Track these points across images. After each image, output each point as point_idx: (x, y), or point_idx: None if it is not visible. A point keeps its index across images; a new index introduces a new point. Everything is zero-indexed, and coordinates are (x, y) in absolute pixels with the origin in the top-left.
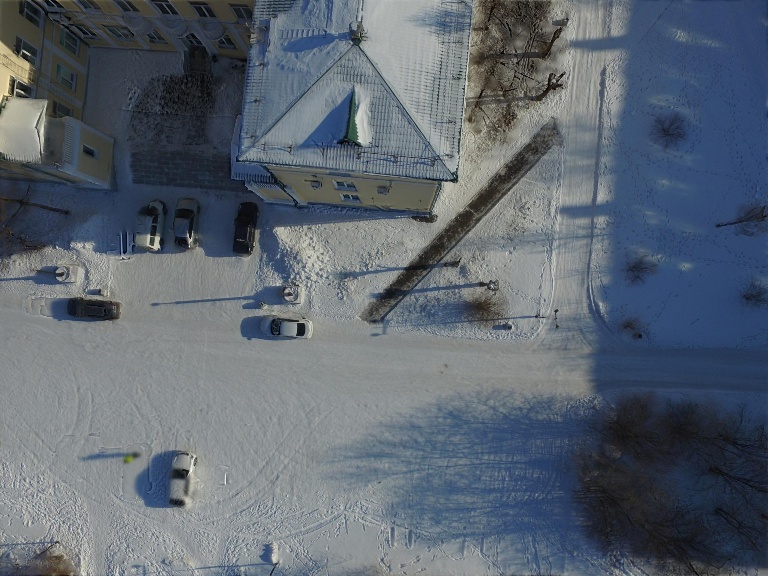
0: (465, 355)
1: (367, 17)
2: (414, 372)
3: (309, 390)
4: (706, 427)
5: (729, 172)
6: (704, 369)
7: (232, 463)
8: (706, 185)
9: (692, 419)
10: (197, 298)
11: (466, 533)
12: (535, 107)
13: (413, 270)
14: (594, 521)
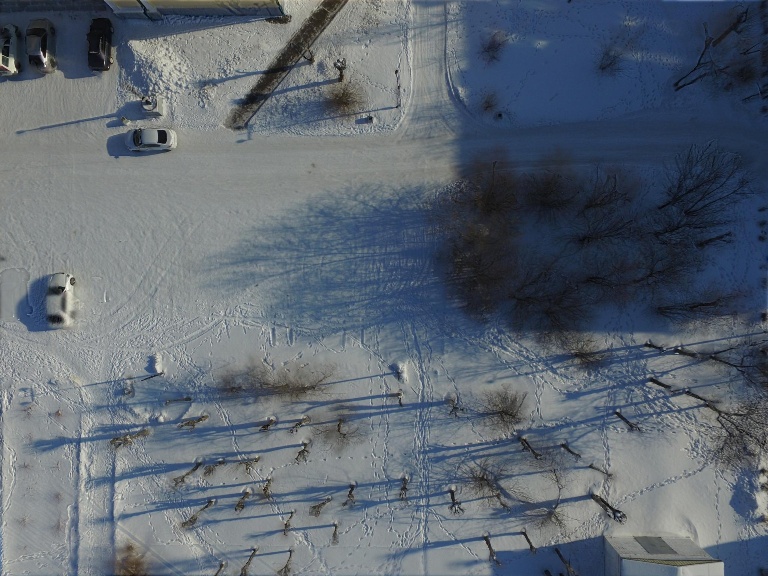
0: (331, 153)
1: None
2: (282, 174)
3: (180, 202)
4: (566, 191)
5: None
6: (568, 145)
7: (110, 281)
8: None
9: None
10: (61, 121)
11: (346, 326)
12: None
13: (272, 73)
14: (469, 301)
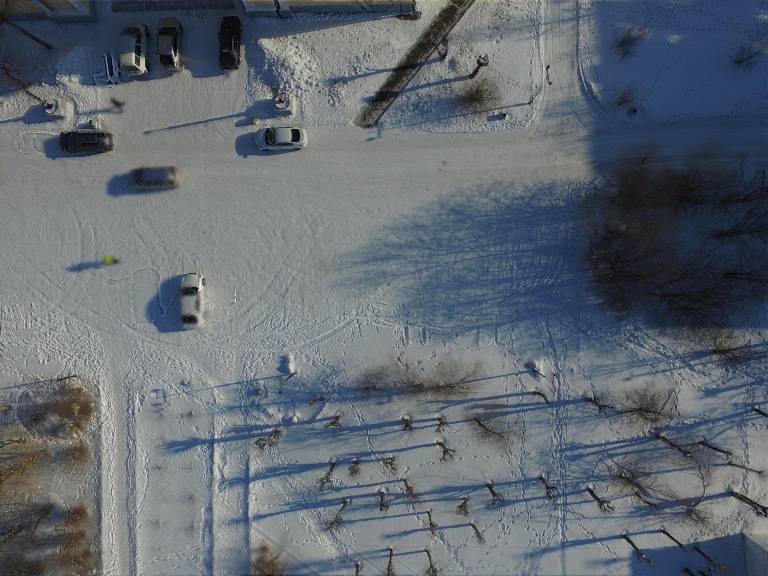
0: (462, 150)
1: None
2: (413, 172)
3: (310, 201)
4: (708, 186)
5: None
6: (701, 140)
7: (240, 281)
8: None
9: None
10: (189, 121)
11: (479, 325)
12: None
13: (402, 70)
14: (605, 298)
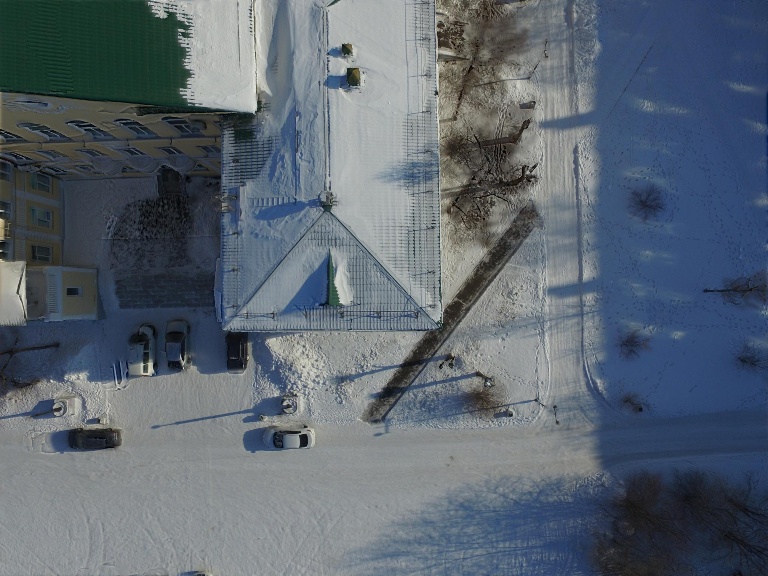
0: (469, 445)
1: (335, 182)
2: (420, 468)
3: (318, 497)
4: (716, 497)
5: (711, 236)
6: (707, 434)
7: None
8: (689, 251)
9: (701, 489)
10: (197, 417)
11: None
12: (512, 192)
13: (408, 366)
14: None
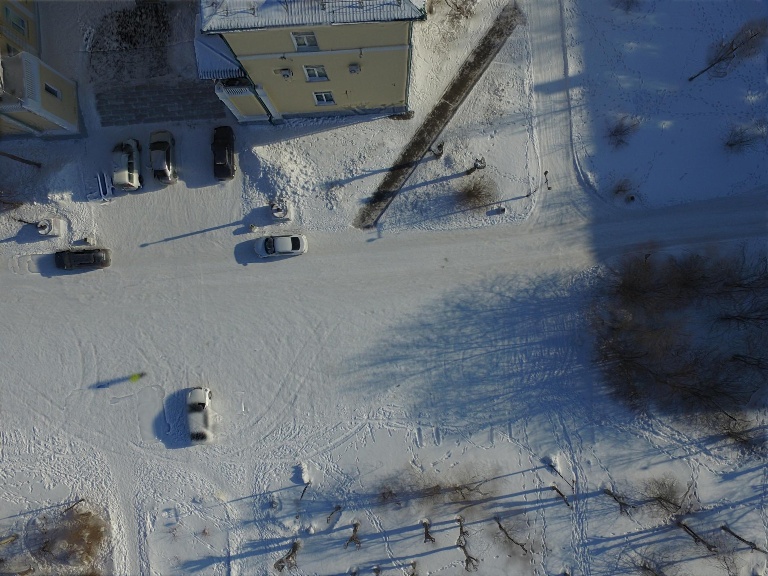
0: (463, 246)
1: None
2: (415, 271)
3: (313, 306)
4: None
5: (693, 25)
6: (700, 222)
7: (247, 391)
8: (673, 41)
9: (696, 269)
10: (186, 232)
11: (492, 421)
12: None
13: (398, 170)
14: (616, 387)
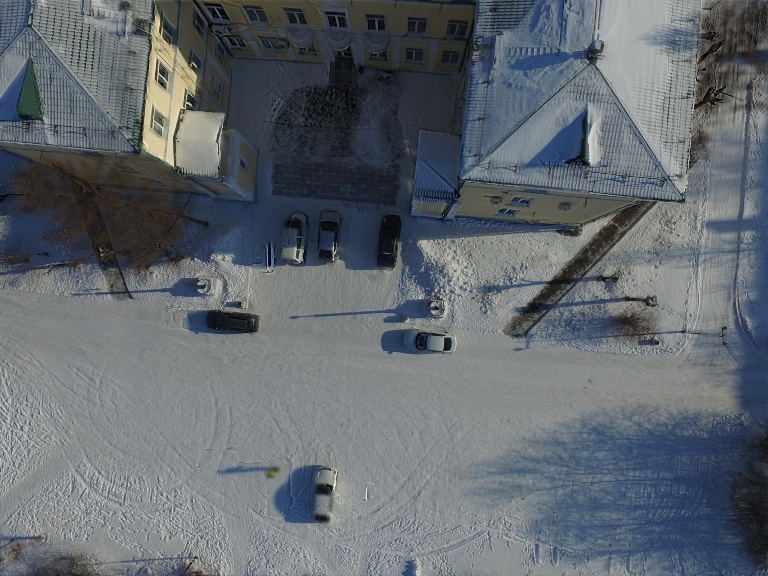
0: (609, 370)
1: (603, 36)
2: (558, 387)
3: (451, 405)
4: None
5: None
6: None
7: (373, 478)
8: None
9: None
10: (337, 311)
11: (612, 550)
12: None
13: (557, 284)
14: (743, 539)
